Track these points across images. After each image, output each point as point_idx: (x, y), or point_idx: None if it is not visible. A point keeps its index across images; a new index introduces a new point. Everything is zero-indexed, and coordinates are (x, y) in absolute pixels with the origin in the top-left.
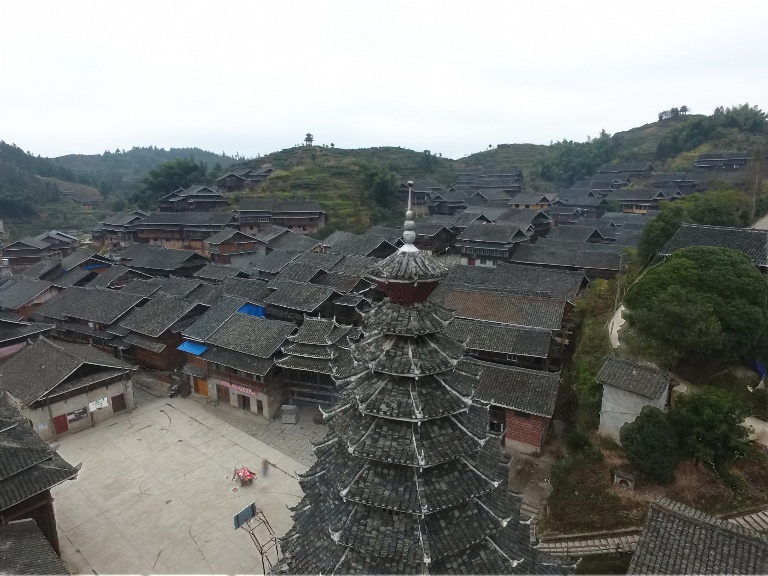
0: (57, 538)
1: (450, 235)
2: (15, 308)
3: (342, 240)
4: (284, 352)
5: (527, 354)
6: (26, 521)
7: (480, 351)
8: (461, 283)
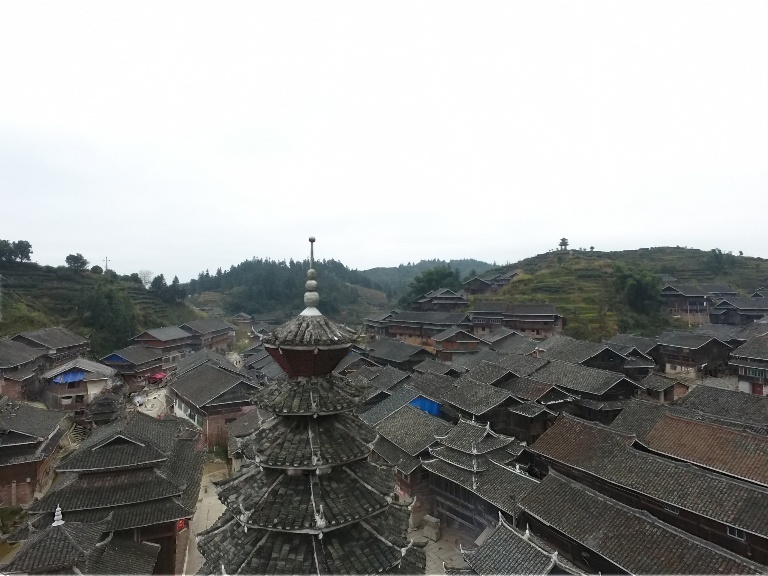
0: (174, 572)
1: (728, 350)
2: (273, 378)
3: (558, 344)
4: (431, 453)
5: (759, 533)
6: (155, 546)
7: (679, 509)
8: (692, 410)
